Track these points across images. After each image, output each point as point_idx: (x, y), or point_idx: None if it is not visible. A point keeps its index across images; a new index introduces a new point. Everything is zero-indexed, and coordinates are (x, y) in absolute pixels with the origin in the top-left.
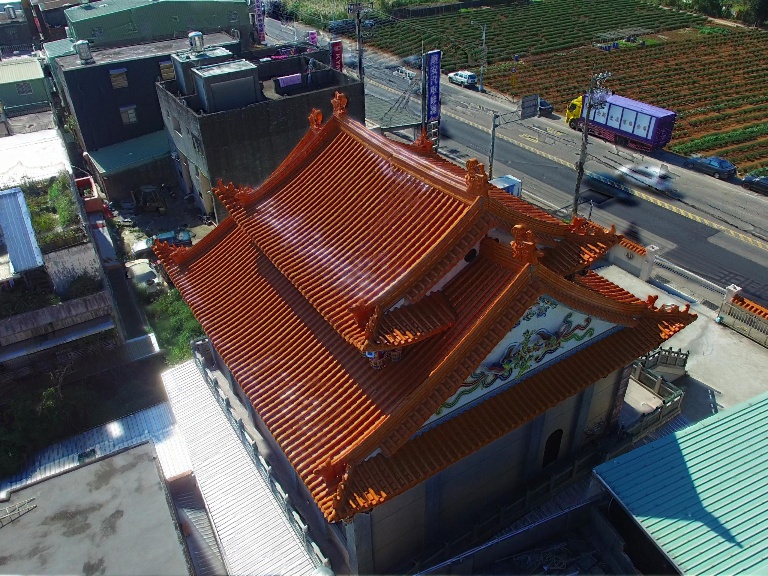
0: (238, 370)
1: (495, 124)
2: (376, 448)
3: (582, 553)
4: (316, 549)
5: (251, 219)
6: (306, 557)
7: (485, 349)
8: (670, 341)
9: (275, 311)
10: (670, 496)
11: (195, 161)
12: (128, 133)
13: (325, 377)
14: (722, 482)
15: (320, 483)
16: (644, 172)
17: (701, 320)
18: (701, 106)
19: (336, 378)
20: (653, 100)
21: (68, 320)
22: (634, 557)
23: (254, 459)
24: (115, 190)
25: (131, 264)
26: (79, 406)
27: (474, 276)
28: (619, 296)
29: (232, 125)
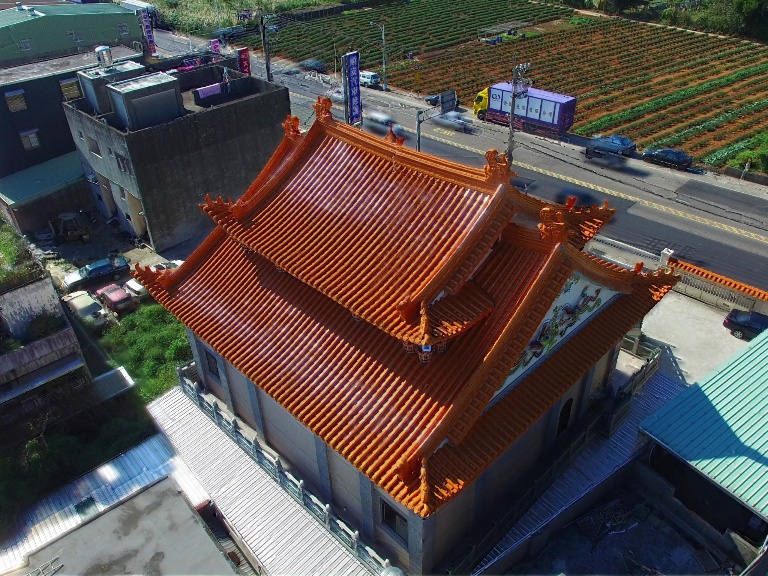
0: (270, 386)
1: (419, 120)
2: (443, 439)
3: (635, 505)
4: (372, 552)
5: (250, 232)
6: (357, 563)
7: (531, 329)
8: None
9: (293, 322)
10: (712, 438)
11: (120, 182)
12: (31, 159)
13: (368, 379)
14: (750, 419)
15: (396, 482)
16: (556, 155)
17: None
18: (590, 90)
19: (381, 378)
20: (547, 88)
21: (31, 364)
22: (684, 500)
23: (277, 476)
24: (27, 222)
25: (68, 298)
26: (63, 454)
27: (502, 261)
28: (606, 267)
29: (160, 141)
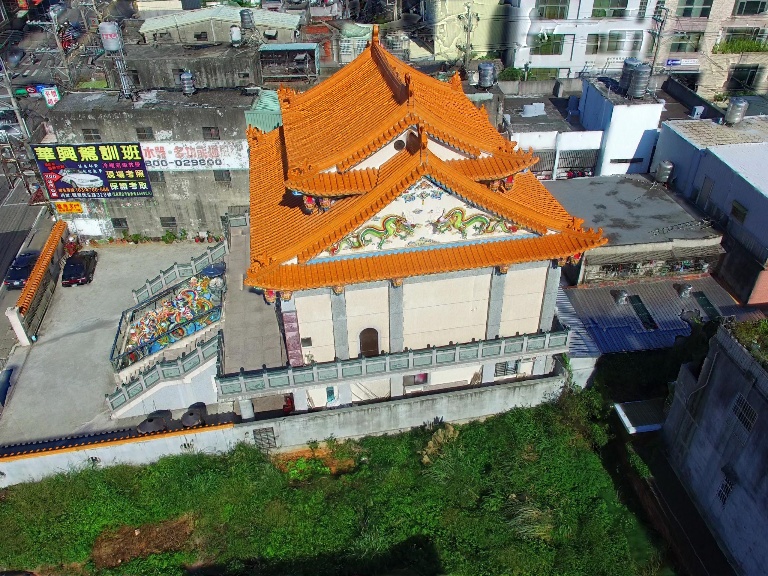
0: None
1: None
2: None
3: None
4: None
5: None
6: None
7: None
8: (103, 336)
9: None
10: None
11: None
12: None
13: None
14: None
15: None
16: None
17: (43, 347)
18: None
19: None
20: None
21: None
22: None
23: None
24: None
25: None
26: None
27: None
28: None
29: None
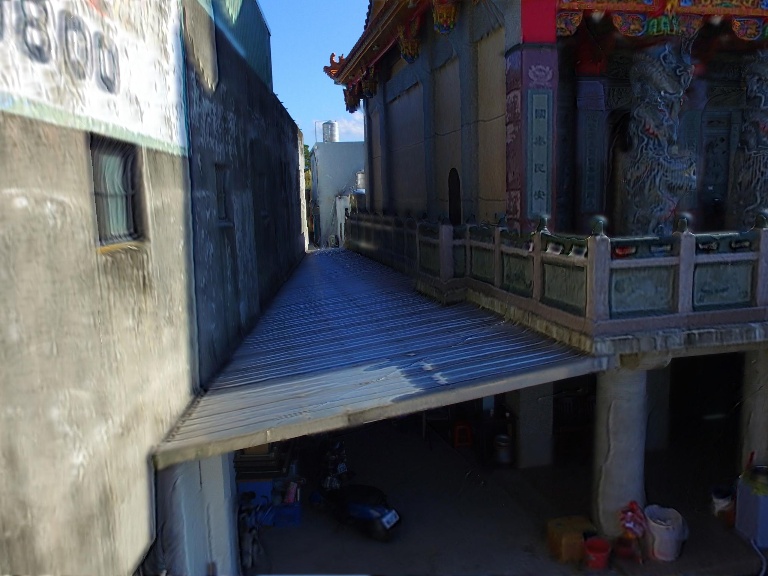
0: None
1: None
2: None
3: None
4: None
5: None
6: None
7: None
8: None
9: None
10: None
11: None
12: None
13: None
14: None
15: None
16: None
17: None
18: None
19: None
20: None
21: None
22: None
23: None
24: None
25: None
26: None
27: None
28: None
29: None
